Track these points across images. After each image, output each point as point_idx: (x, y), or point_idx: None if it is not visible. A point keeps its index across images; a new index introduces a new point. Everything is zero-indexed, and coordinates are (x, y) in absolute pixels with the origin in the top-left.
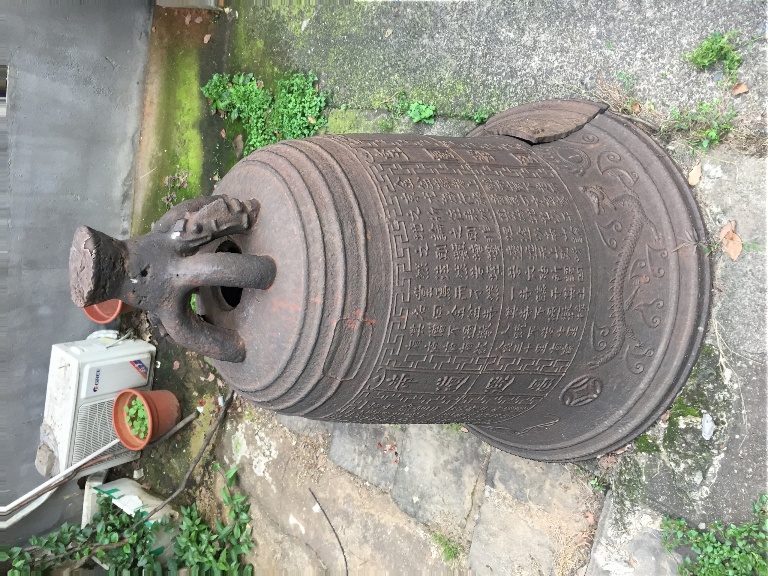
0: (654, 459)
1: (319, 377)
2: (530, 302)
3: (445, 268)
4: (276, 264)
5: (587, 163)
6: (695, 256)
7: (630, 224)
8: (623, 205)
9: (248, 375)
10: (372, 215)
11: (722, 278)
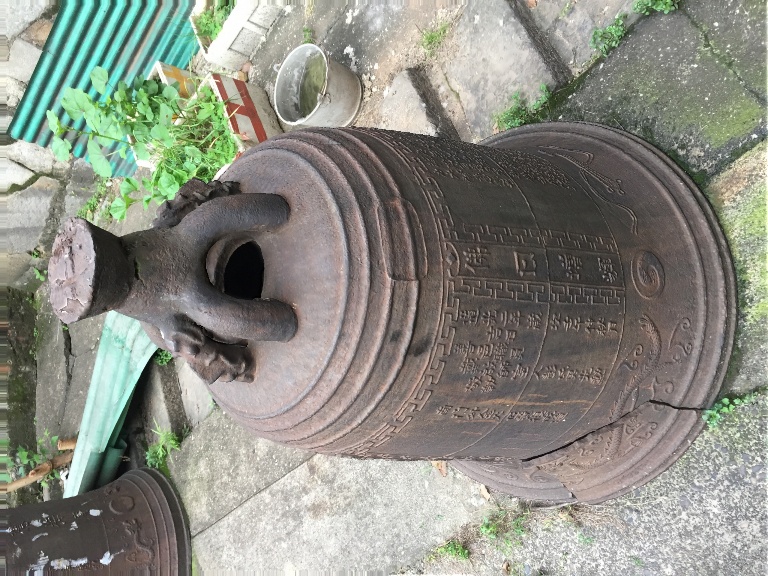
0: None
1: None
2: None
3: None
4: None
5: None
6: None
7: None
8: None
9: None
10: None
11: None
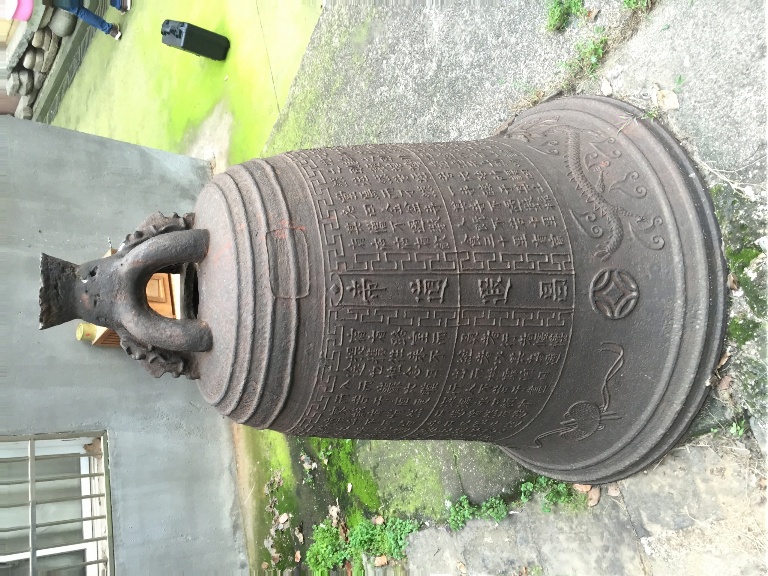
0: (761, 339)
1: (272, 301)
2: (477, 197)
3: (363, 178)
4: (208, 230)
5: (511, 132)
6: (639, 125)
7: (565, 138)
8: (553, 133)
9: (222, 357)
10: (280, 163)
11: (681, 129)
